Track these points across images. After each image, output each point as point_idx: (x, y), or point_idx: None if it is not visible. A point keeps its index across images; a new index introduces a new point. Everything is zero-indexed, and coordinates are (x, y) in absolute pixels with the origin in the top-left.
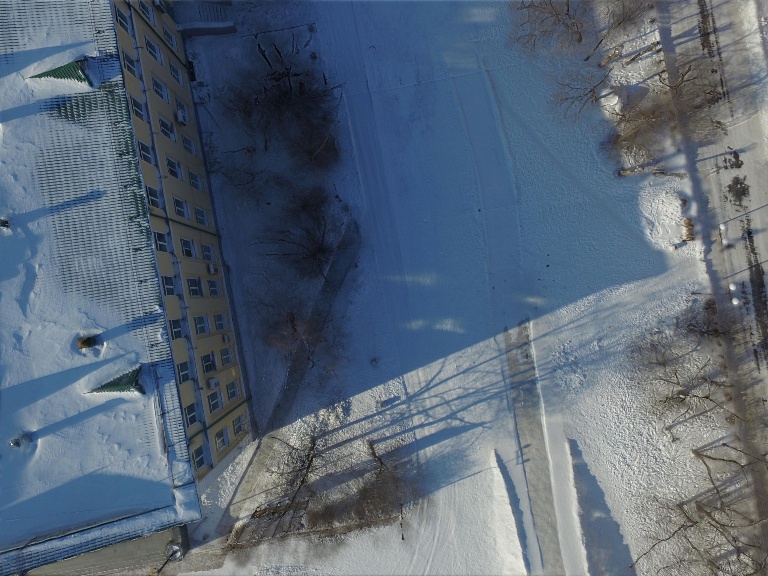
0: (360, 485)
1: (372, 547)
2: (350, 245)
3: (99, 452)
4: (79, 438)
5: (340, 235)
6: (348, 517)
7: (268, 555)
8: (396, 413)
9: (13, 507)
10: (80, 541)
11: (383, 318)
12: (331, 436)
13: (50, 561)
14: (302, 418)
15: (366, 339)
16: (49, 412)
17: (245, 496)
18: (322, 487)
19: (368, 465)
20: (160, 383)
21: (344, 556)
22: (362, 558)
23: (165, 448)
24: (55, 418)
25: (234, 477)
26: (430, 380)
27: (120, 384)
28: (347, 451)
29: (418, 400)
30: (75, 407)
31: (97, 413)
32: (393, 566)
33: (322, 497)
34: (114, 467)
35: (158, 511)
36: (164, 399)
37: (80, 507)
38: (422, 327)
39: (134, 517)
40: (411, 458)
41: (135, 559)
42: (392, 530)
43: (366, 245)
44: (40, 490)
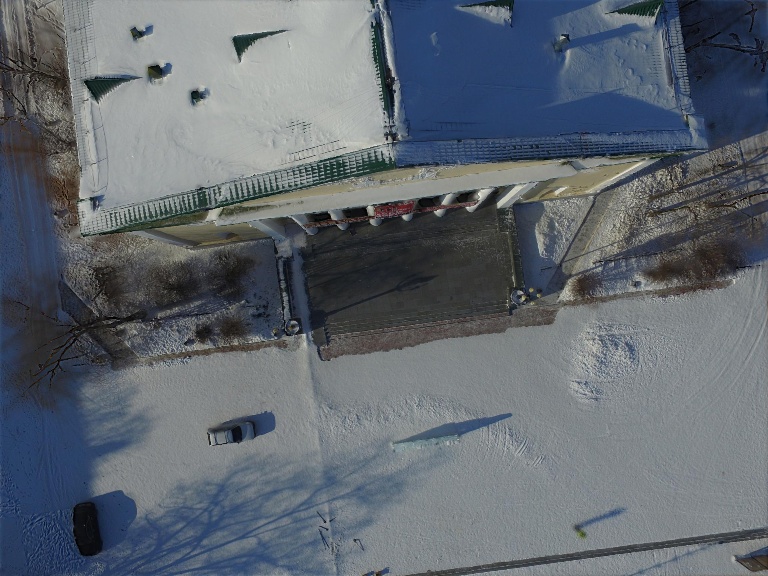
0: (696, 246)
1: (705, 309)
2: (688, 13)
3: (616, 74)
4: (601, 56)
5: (681, 1)
6: (686, 275)
7: (600, 313)
8: (732, 178)
9: (552, 108)
10: (622, 141)
11: (721, 84)
12: (667, 197)
13: (601, 153)
14: (639, 178)
15: (705, 103)
16: (576, 26)
17: (578, 253)
18: (657, 247)
19: (704, 227)
20: (667, 17)
21: (677, 317)
22: (695, 320)
23: (672, 80)
24: (581, 33)
25: (569, 233)
26: (767, 147)
27: (649, 1)
28: (682, 213)
29: (755, 166)
30: (596, 26)
31: (615, 36)
32: (726, 329)
33: (657, 257)
34: (629, 90)
35: (678, 131)
36: (670, 34)
37: (604, 121)
38: (759, 95)
39: (661, 131)
40: (746, 223)
41: (469, 309)
42: (726, 293)
43: (705, 13)
44: (570, 98)
